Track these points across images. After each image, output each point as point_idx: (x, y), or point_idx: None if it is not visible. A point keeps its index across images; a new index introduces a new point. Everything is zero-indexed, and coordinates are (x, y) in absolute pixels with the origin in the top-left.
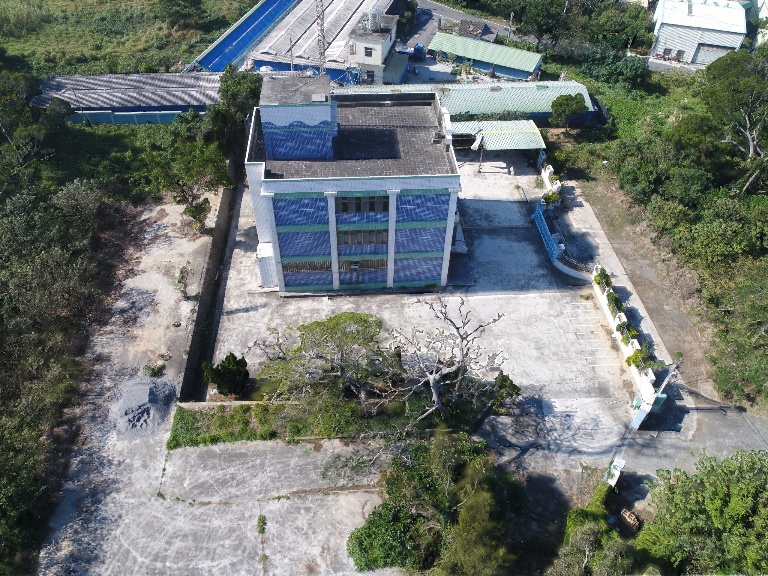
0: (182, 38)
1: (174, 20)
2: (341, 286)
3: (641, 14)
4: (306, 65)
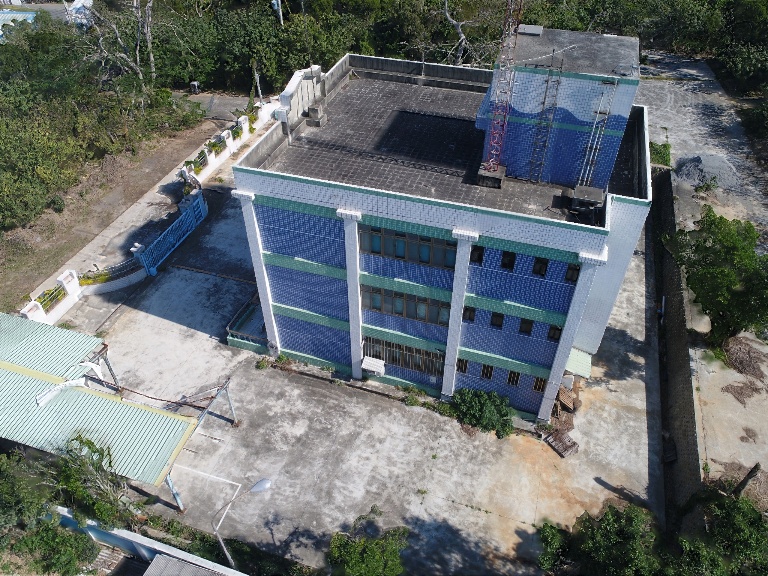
0: None
1: None
2: None
3: None
4: None
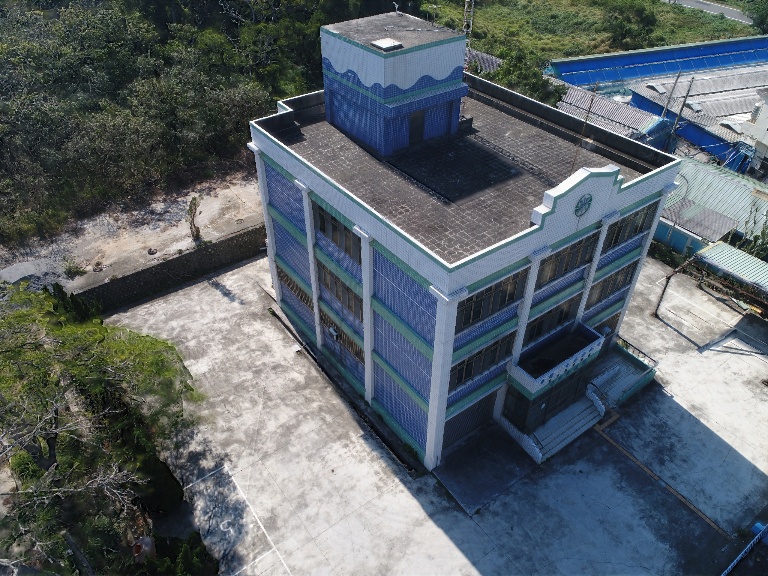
0: None
1: (608, 32)
2: (323, 348)
3: None
4: (685, 117)
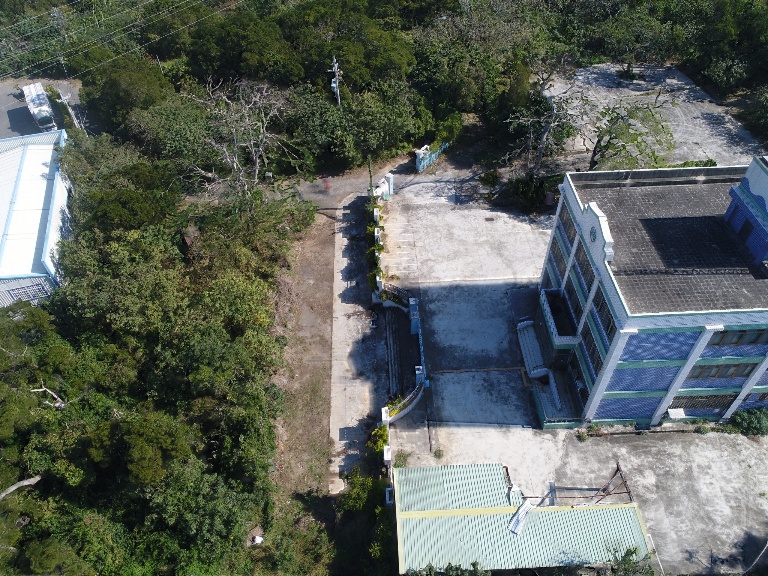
0: None
1: None
2: None
3: None
4: None
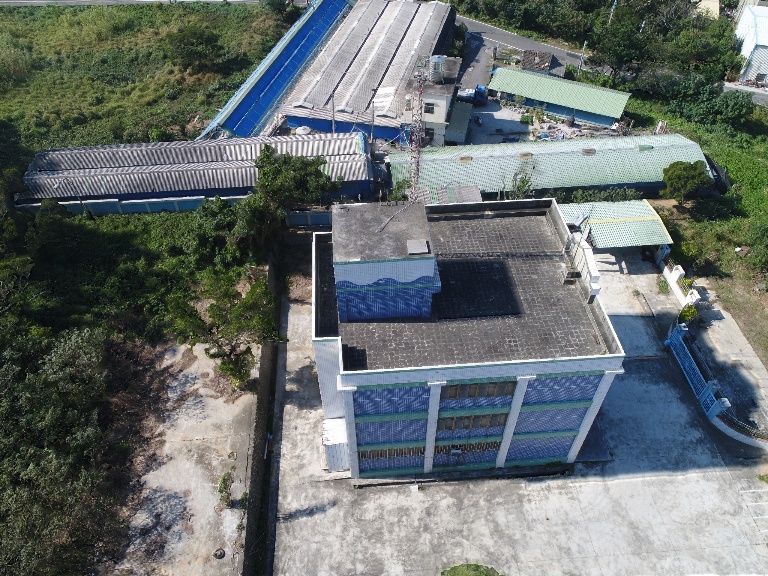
0: (197, 84)
1: (187, 63)
2: (434, 469)
3: (727, 32)
4: (350, 122)
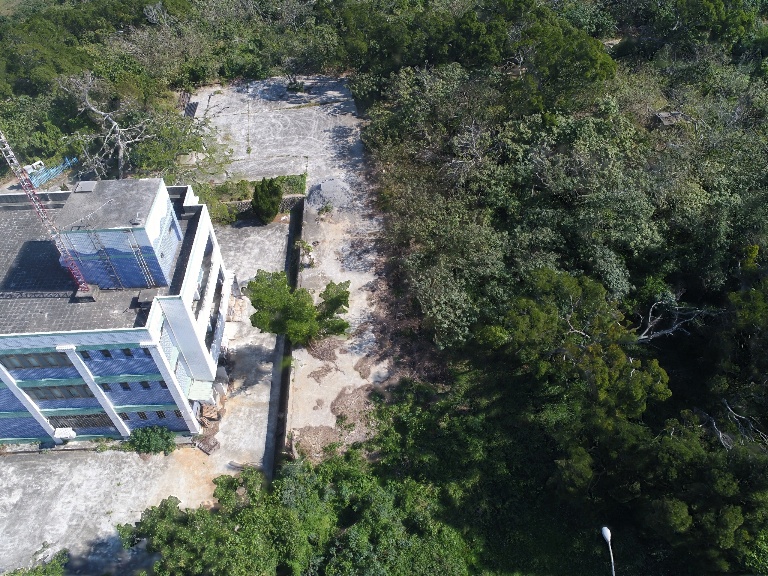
0: None
1: None
2: None
3: None
4: None
